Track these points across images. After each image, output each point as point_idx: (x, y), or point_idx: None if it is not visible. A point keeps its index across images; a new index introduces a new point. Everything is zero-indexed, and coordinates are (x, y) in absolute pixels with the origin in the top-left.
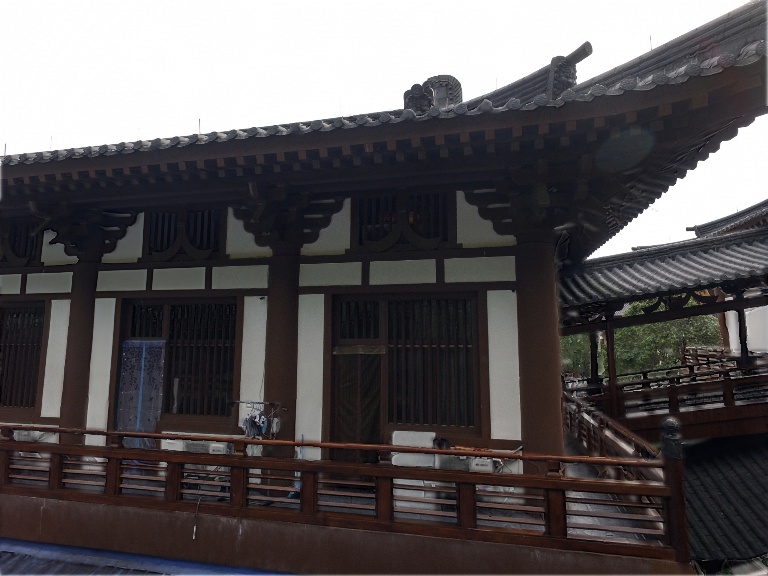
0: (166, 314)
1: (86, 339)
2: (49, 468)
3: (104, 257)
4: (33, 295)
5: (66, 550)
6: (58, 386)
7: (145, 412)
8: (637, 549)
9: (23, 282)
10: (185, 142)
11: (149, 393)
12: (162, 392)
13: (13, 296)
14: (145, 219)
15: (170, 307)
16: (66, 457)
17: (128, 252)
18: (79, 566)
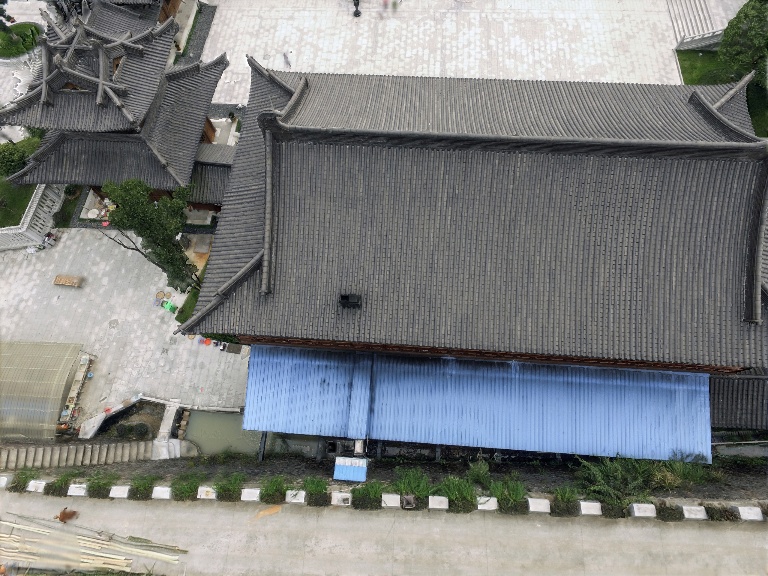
0: None
1: None
2: None
3: None
4: None
5: (597, 366)
6: None
7: None
8: (730, 372)
9: None
10: (690, 363)
11: None
12: None
13: None
14: None
15: None
16: None
17: None
18: (604, 370)
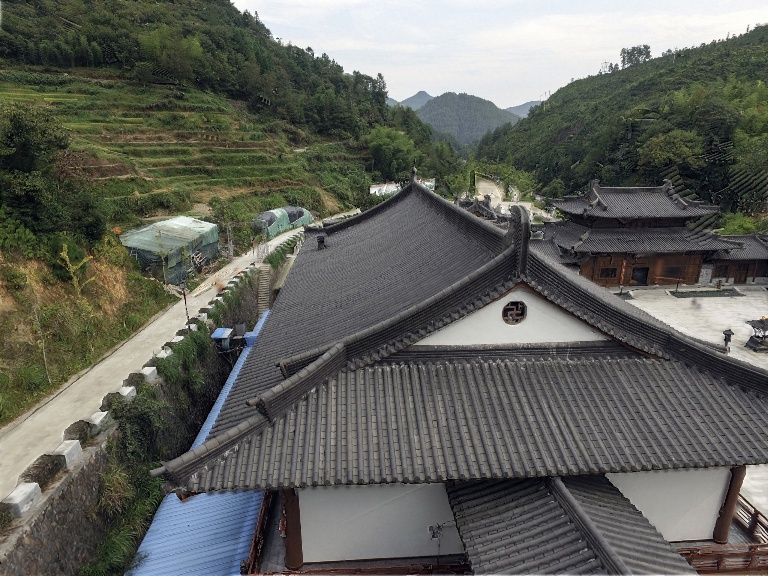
0: None
1: None
2: None
3: None
4: None
5: None
6: None
7: None
8: None
9: None
10: None
11: None
12: None
13: None
14: None
15: None
16: None
17: None
18: None
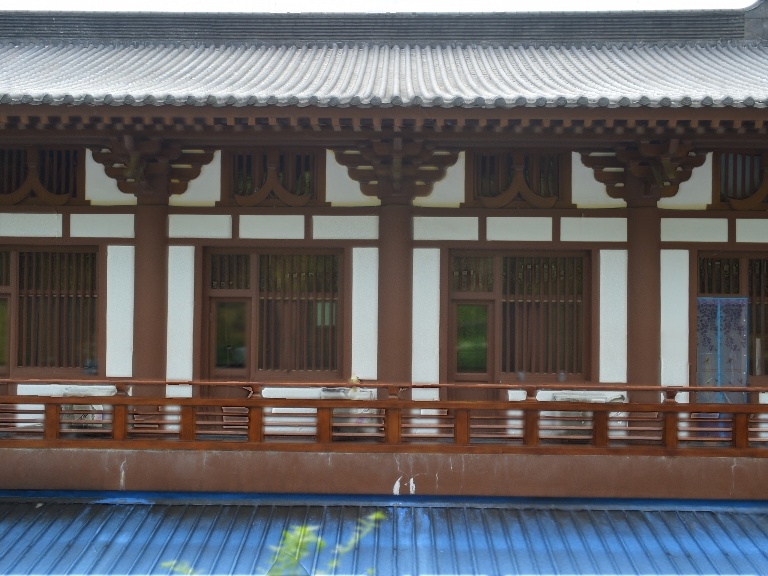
0: (744, 269)
1: (655, 295)
2: (733, 428)
3: (661, 201)
4: (573, 243)
5: (763, 505)
6: (621, 348)
7: (724, 374)
8: None
9: (556, 227)
10: None
11: (727, 354)
12: (746, 353)
13: (542, 243)
14: (714, 160)
15: (748, 261)
16: (748, 416)
17: (693, 197)
18: None
